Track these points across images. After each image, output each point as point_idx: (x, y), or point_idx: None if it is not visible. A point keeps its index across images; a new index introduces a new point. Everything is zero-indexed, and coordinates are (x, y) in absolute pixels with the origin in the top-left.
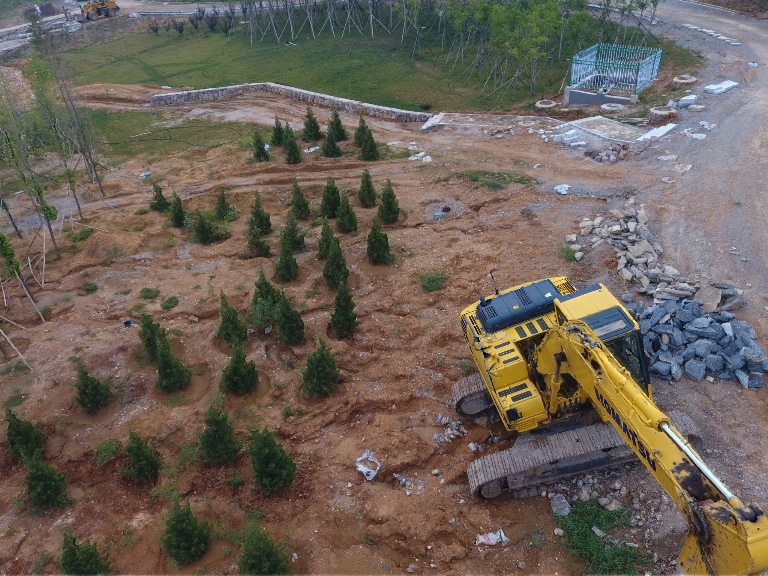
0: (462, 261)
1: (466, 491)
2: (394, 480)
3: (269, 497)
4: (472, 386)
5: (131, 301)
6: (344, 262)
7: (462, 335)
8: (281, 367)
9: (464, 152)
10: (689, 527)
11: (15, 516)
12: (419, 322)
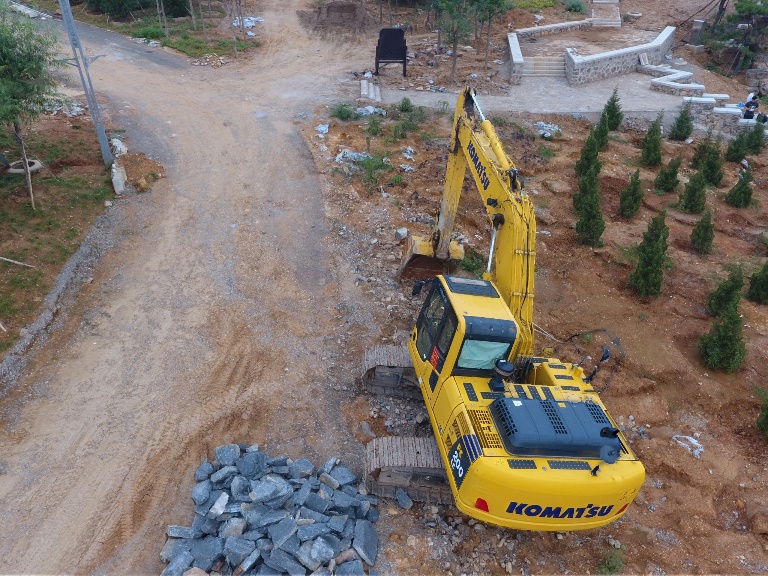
0: None
1: None
2: None
3: None
4: None
5: None
6: None
7: None
8: None
9: None
10: None
11: None
12: None
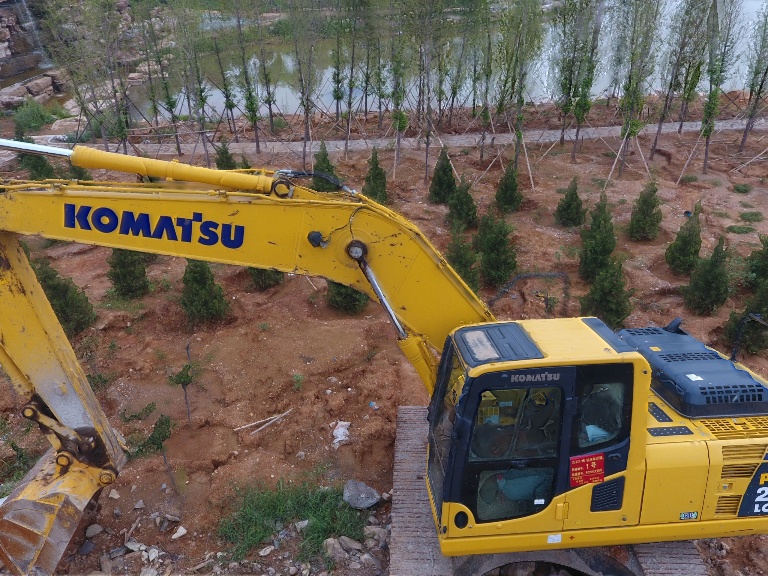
0: None
1: None
2: None
3: None
4: None
5: (732, 210)
6: None
7: None
8: None
9: None
10: None
11: (446, 213)
12: None
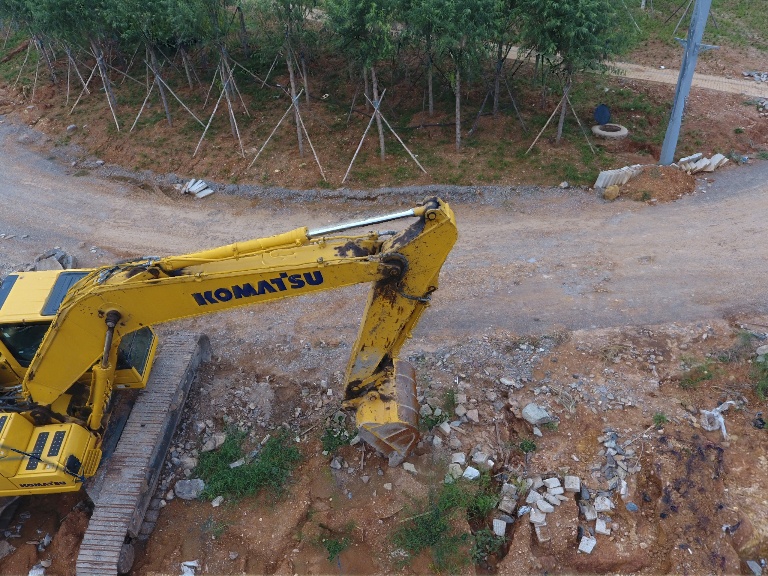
0: None
1: None
2: None
3: None
4: None
5: None
6: None
7: None
8: None
9: None
10: (374, 292)
11: None
12: None
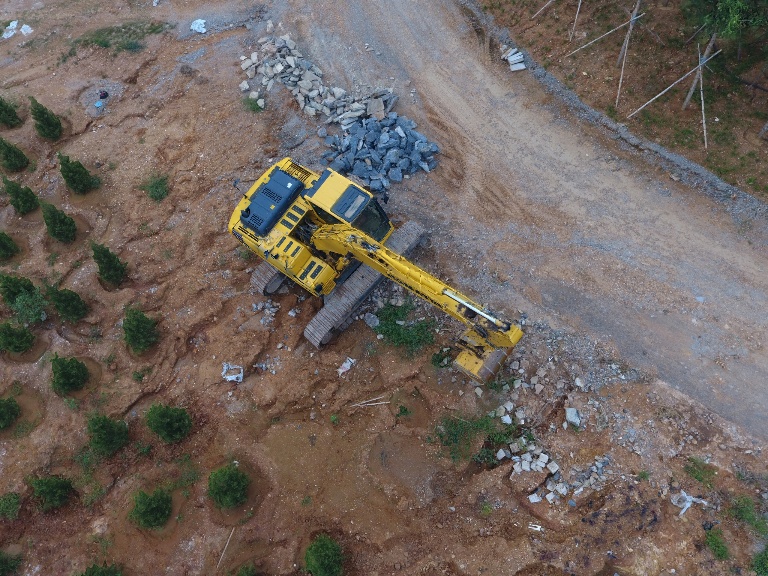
0: (167, 153)
1: (309, 346)
2: (256, 369)
3: (182, 442)
4: (267, 274)
5: None
6: (63, 214)
7: (221, 228)
8: (92, 343)
9: (62, 6)
10: None
11: None
12: (177, 235)
